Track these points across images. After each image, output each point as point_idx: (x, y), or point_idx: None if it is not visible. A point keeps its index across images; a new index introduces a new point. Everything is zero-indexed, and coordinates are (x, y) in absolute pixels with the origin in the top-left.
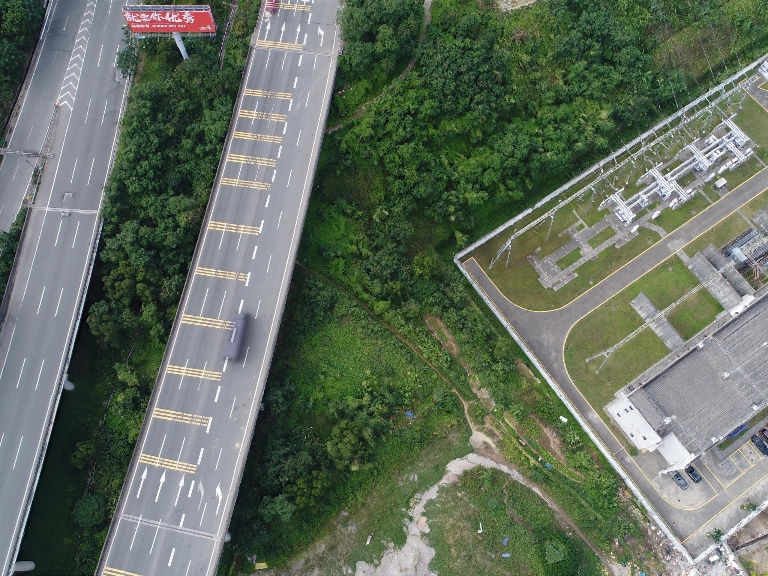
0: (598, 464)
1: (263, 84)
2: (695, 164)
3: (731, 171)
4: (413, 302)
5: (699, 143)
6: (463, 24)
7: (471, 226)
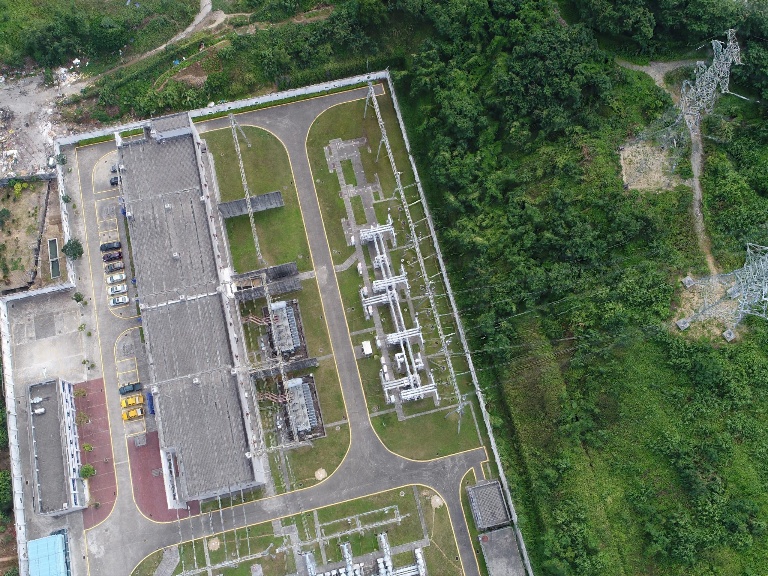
0: None
1: None
2: None
3: None
4: None
5: (425, 358)
6: None
7: None
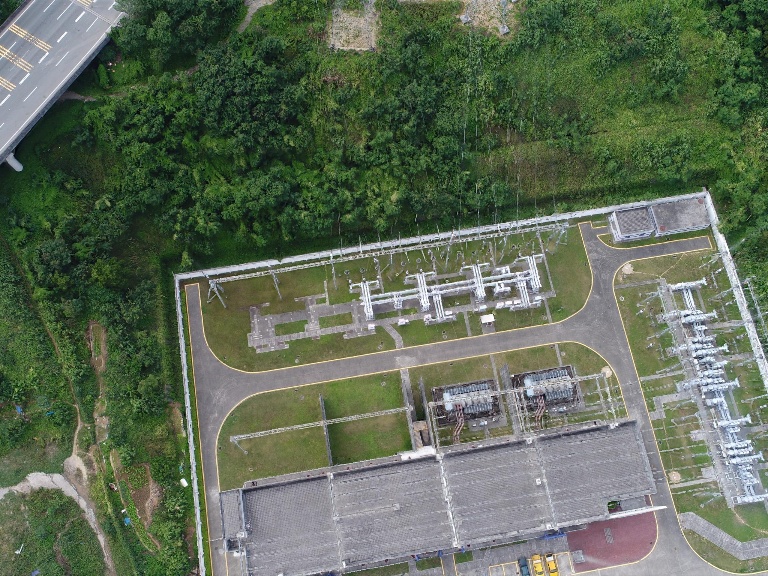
0: (190, 542)
1: (32, 26)
2: (472, 288)
3: (511, 311)
4: (74, 303)
5: None
6: (263, 44)
7: (208, 252)
